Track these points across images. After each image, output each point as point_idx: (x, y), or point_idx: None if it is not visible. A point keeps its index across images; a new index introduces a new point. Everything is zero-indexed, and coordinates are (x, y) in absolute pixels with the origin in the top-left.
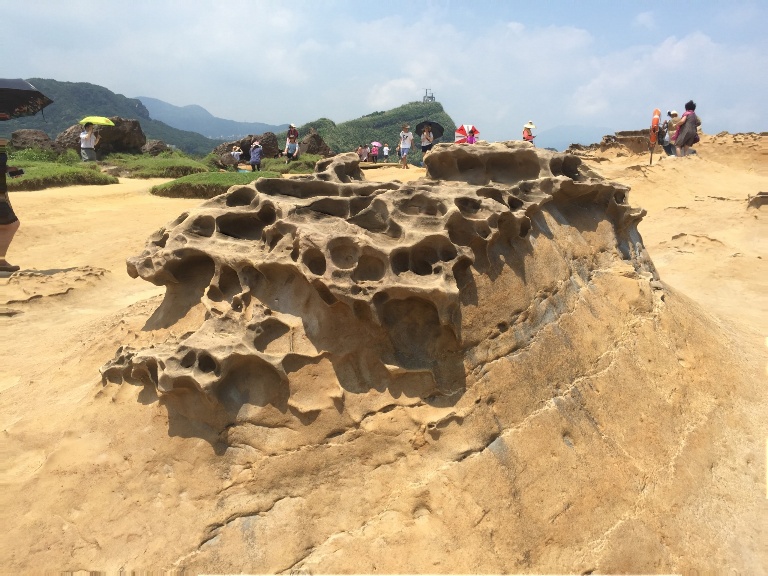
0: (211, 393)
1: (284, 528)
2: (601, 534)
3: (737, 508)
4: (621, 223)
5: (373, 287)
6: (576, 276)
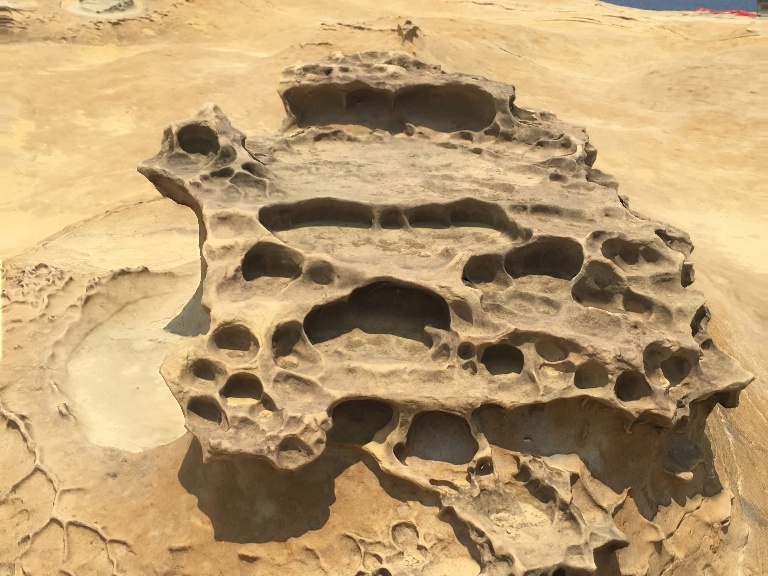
0: None
1: None
2: None
3: None
4: None
5: (686, 395)
6: None
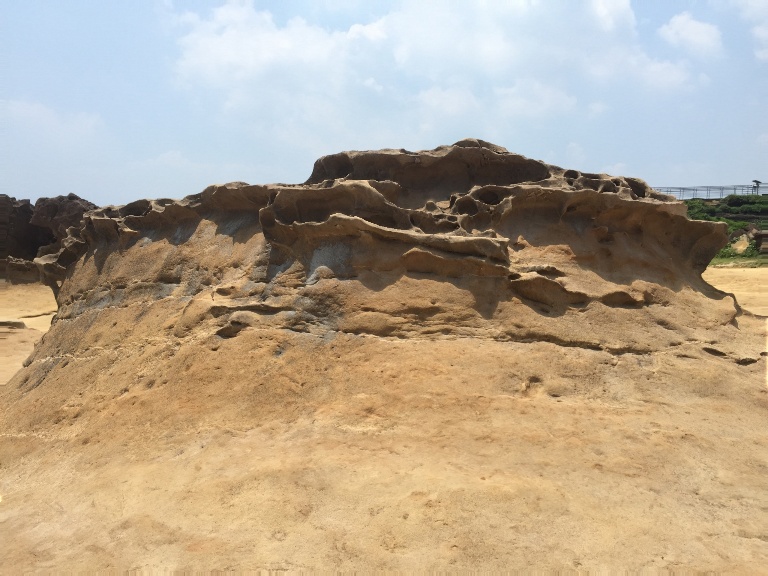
0: None
1: None
2: None
3: None
4: None
5: None
6: (182, 285)
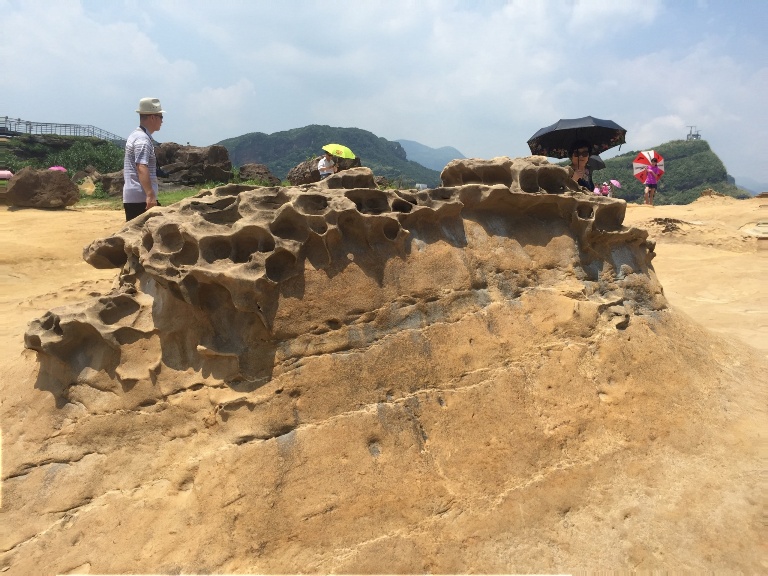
0: (49, 352)
1: (79, 478)
2: (354, 543)
3: (570, 560)
4: (584, 239)
5: (186, 270)
6: (493, 289)
